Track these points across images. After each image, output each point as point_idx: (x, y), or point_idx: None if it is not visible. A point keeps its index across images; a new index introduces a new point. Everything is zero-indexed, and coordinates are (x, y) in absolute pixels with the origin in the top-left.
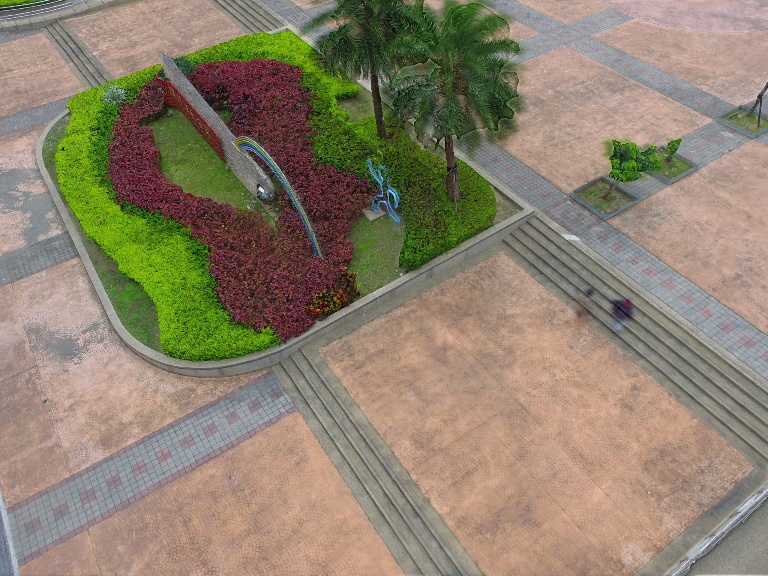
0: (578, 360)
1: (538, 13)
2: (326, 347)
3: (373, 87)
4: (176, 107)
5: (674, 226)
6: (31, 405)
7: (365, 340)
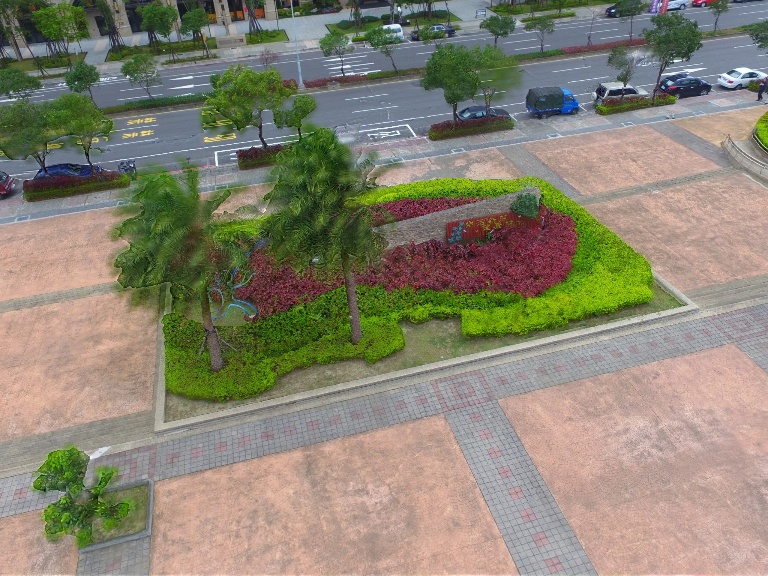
0: (4, 413)
1: None
2: (159, 288)
3: None
4: None
5: (13, 571)
6: (231, 198)
7: (146, 306)
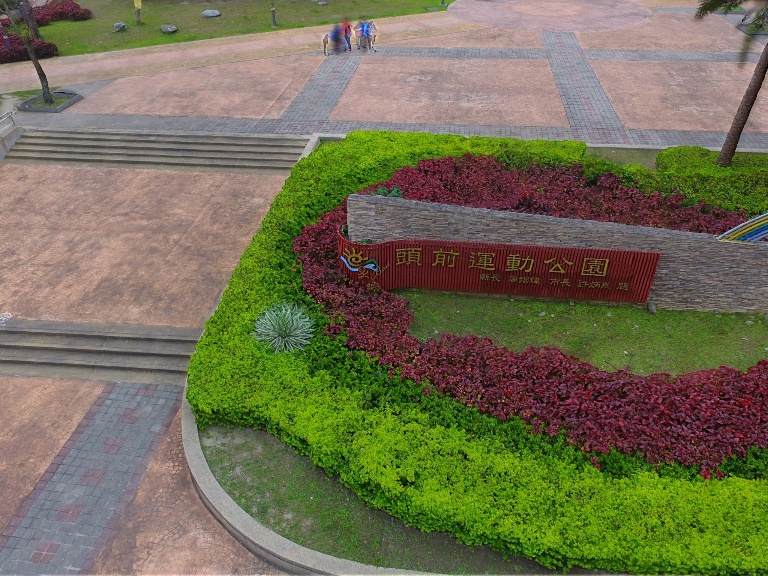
0: None
1: (506, 49)
2: None
3: (759, 86)
4: (390, 290)
5: None
6: None
7: None
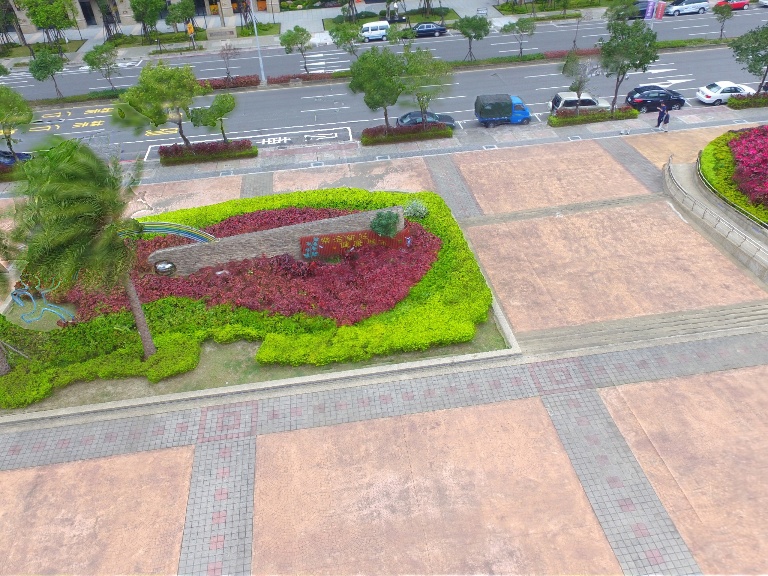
0: None
1: None
2: None
3: None
4: None
5: None
6: None
7: None
